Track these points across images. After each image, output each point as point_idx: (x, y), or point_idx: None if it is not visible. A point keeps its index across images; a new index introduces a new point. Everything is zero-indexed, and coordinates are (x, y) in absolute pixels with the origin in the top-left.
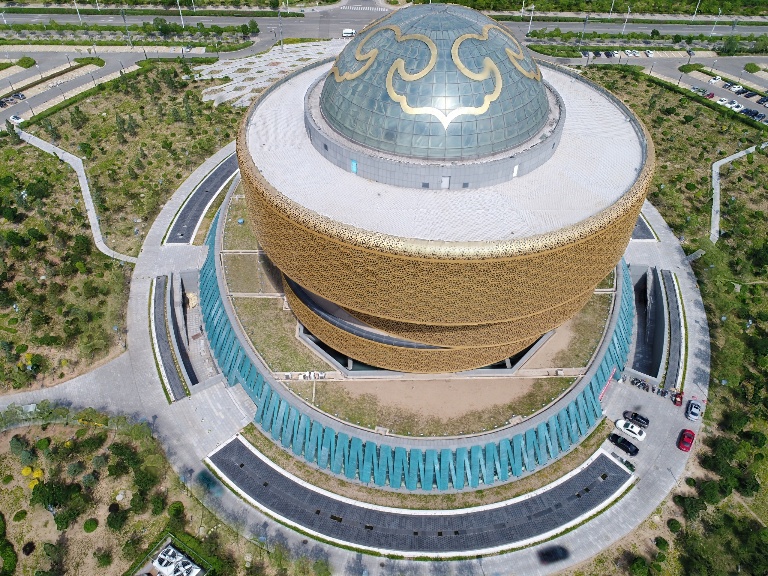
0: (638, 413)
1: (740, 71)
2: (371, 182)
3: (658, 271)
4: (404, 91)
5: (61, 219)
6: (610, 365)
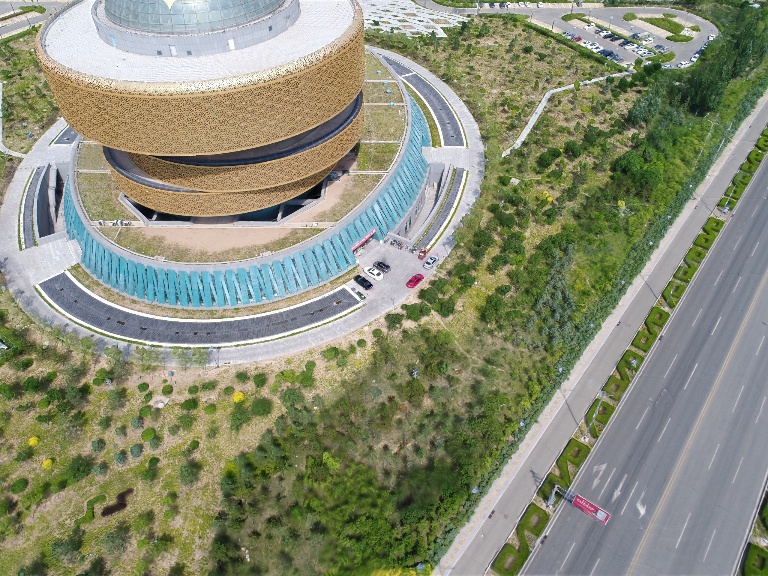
0: (386, 263)
1: (618, 19)
2: (124, 52)
3: (451, 167)
4: None
5: None
6: (367, 226)
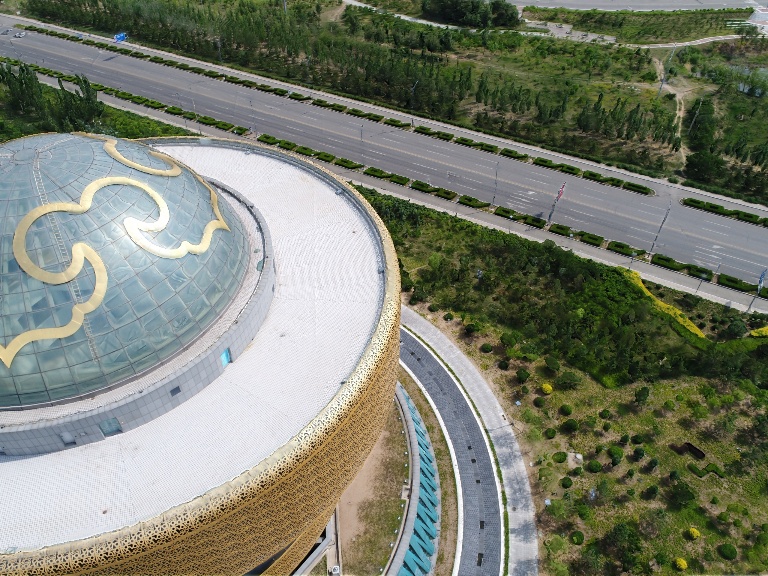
0: None
1: None
2: (252, 346)
3: None
4: (174, 239)
5: None
6: None
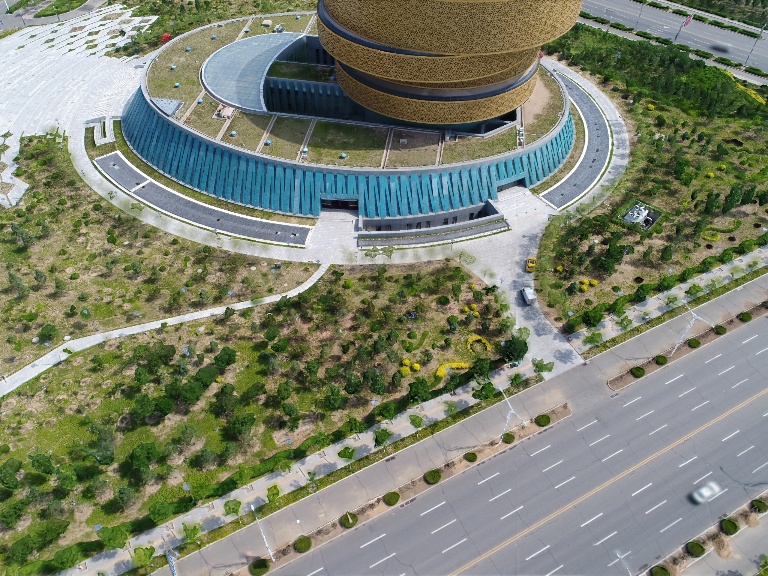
0: None
1: None
2: None
3: None
4: None
5: (223, 336)
6: None
